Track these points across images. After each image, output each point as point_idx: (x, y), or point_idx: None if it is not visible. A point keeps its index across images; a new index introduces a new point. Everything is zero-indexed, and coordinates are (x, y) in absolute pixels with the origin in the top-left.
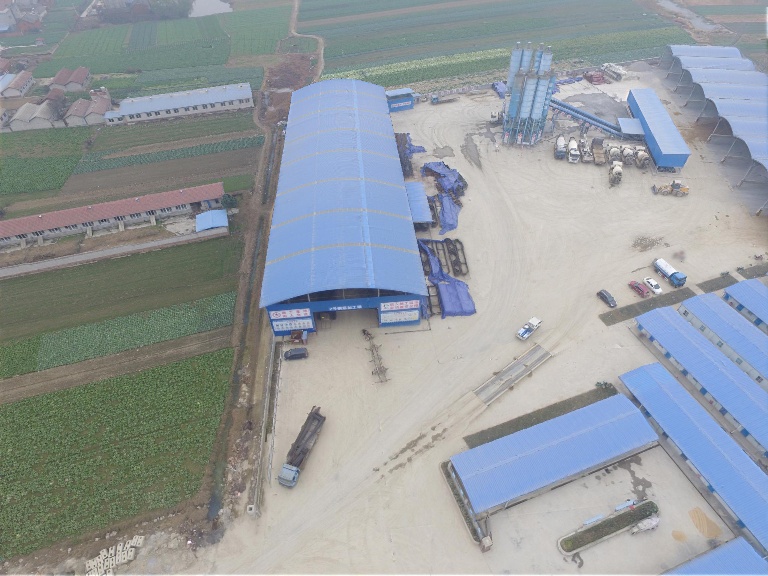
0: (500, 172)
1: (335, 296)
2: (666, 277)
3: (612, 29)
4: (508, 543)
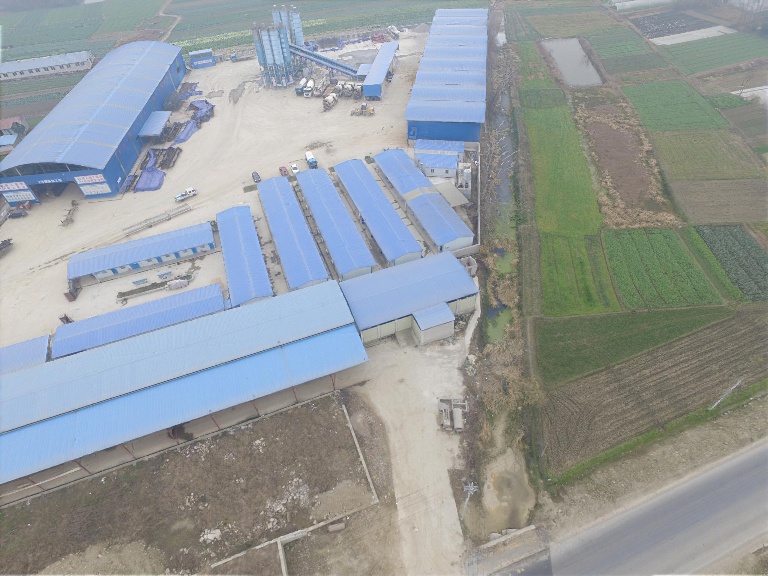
0: (247, 106)
1: (38, 171)
2: (307, 163)
3: (428, 1)
4: (89, 297)
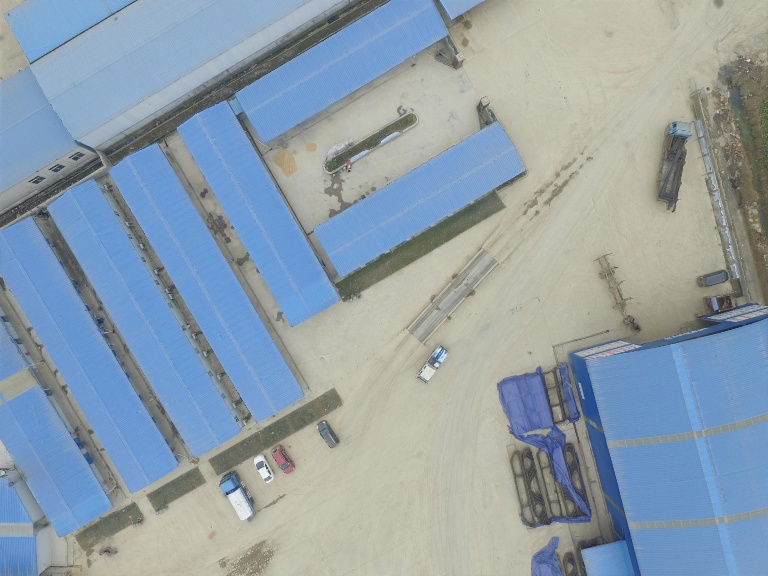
0: None
1: None
2: (243, 487)
3: None
4: (461, 115)
